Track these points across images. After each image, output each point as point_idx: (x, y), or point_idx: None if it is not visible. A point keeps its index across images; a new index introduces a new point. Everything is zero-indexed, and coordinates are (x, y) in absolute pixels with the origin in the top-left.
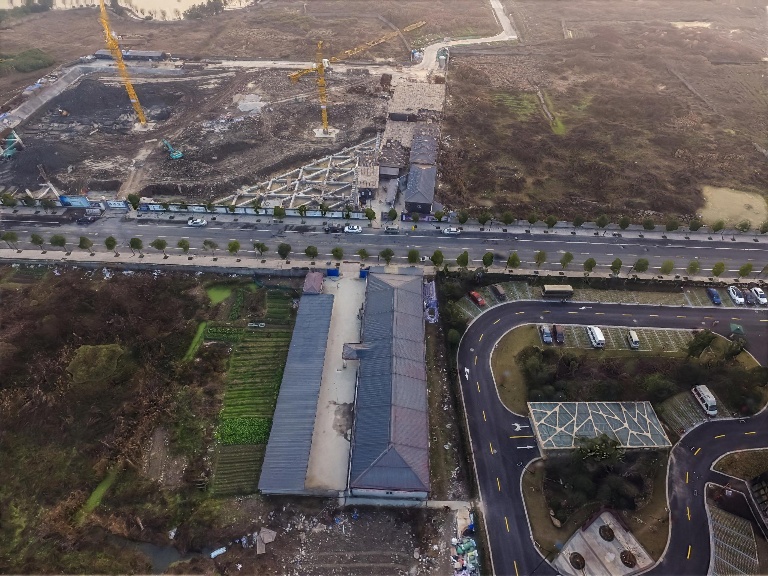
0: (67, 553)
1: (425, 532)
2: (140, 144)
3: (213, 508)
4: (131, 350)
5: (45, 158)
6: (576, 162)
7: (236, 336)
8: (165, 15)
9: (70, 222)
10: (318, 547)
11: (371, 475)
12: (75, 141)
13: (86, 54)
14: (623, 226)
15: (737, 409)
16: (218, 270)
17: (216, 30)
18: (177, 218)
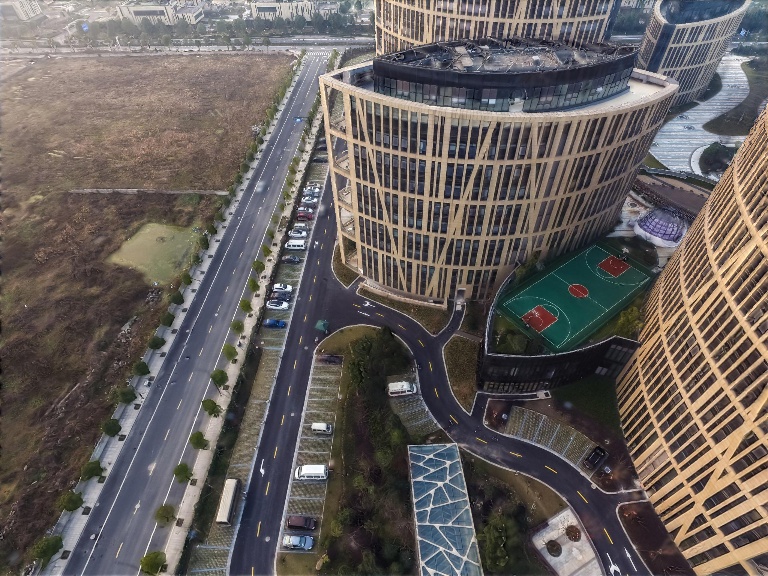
0: None
1: None
2: None
3: None
4: None
5: None
6: None
7: None
8: None
9: None
10: None
11: None
12: None
13: None
14: (144, 372)
15: (408, 366)
16: None
17: None
18: None
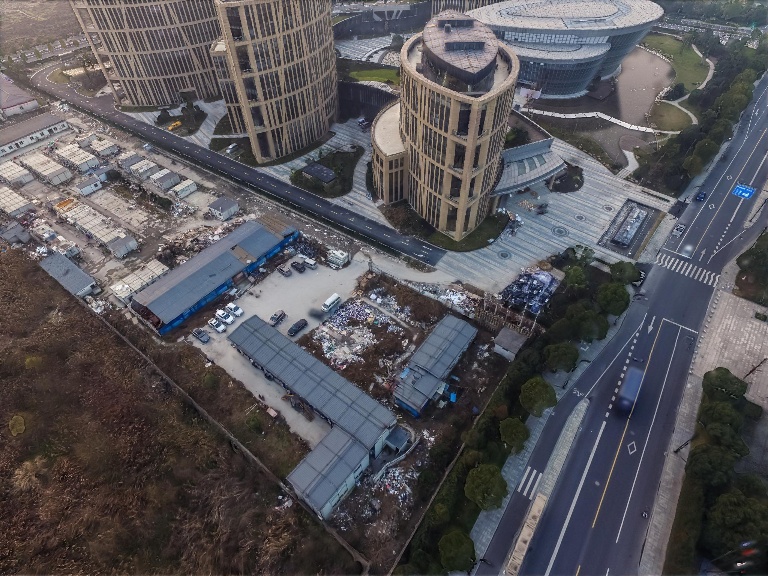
0: None
1: (45, 111)
2: None
3: None
4: None
5: None
6: (57, 25)
7: None
8: None
9: None
10: (3, 128)
11: (7, 104)
12: None
13: None
14: None
15: None
16: None
17: None
18: None
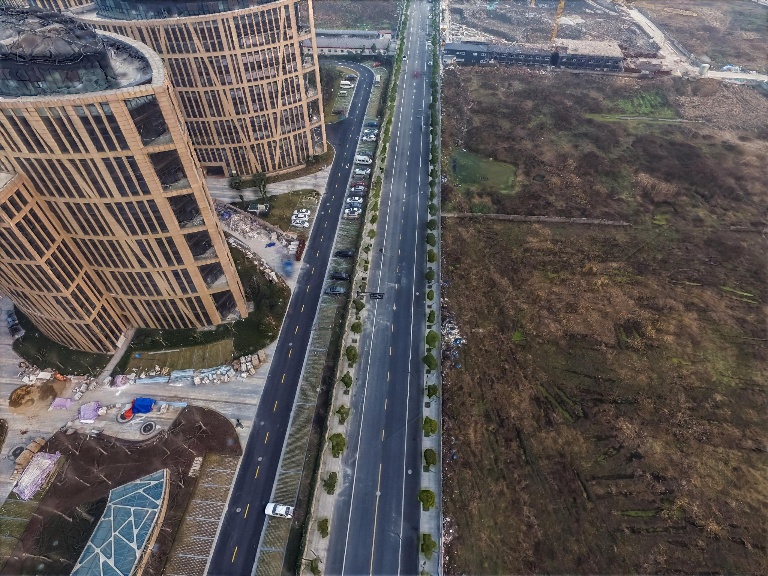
0: None
1: None
2: (503, 4)
3: None
4: (356, 14)
5: None
6: None
7: None
8: None
9: None
10: None
11: None
12: None
13: None
14: None
15: None
16: None
17: (700, 3)
18: None
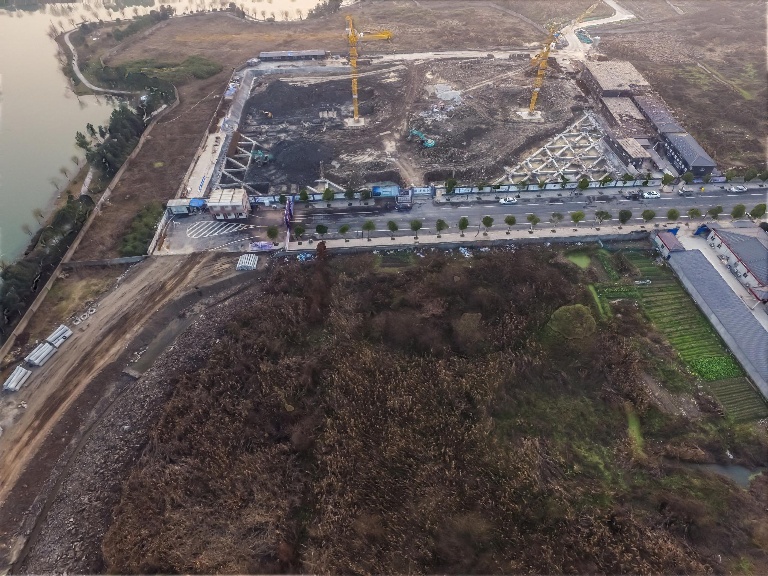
0: (660, 478)
1: None
2: (378, 137)
3: (748, 430)
4: None
5: (310, 156)
6: None
7: (635, 293)
8: (287, 16)
9: (389, 210)
10: None
11: None
12: (315, 139)
13: (246, 58)
14: None
15: None
16: (566, 240)
17: None
18: (484, 199)
